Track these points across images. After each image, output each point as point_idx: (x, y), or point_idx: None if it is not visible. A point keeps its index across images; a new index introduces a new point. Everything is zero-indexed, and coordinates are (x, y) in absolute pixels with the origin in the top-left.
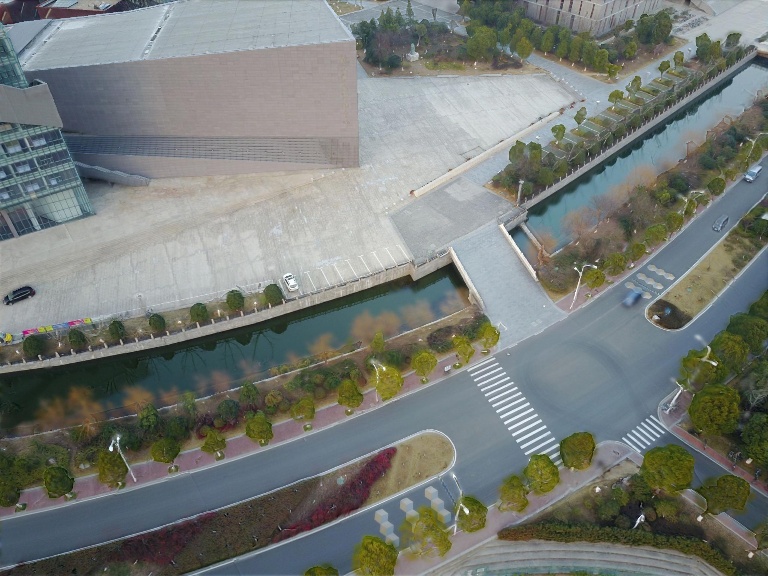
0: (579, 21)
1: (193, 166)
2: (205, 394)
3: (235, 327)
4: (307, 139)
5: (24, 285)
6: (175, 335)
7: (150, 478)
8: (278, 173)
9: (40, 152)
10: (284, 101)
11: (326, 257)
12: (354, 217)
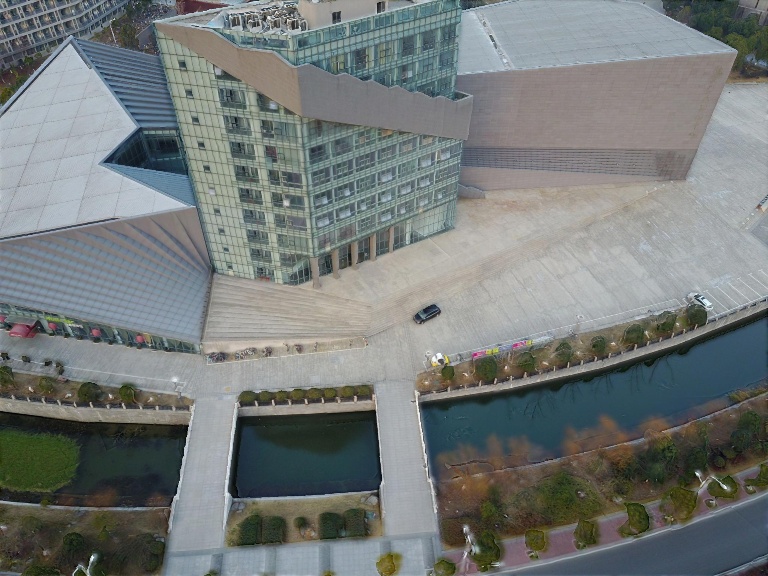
0: None
1: (528, 178)
2: (677, 421)
3: (660, 349)
4: (645, 151)
5: (424, 303)
6: (614, 357)
7: (693, 513)
8: (607, 185)
9: (441, 165)
10: (638, 112)
11: (715, 275)
12: (716, 233)
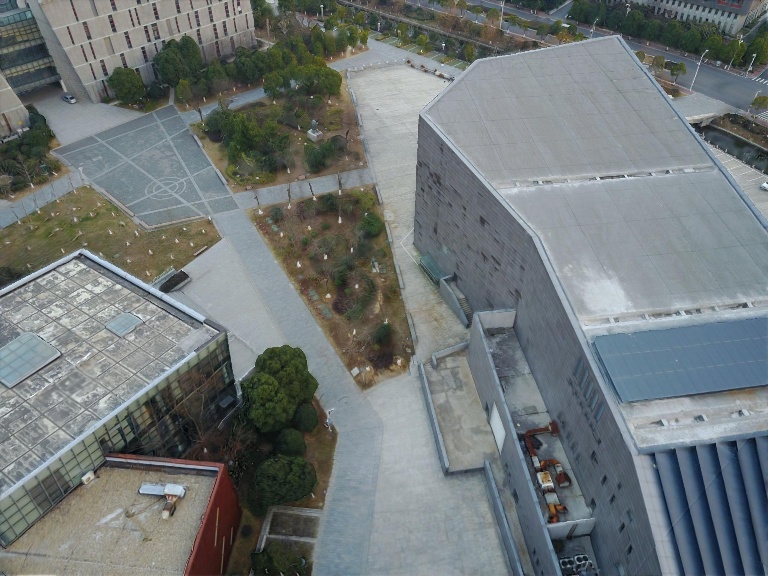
0: (240, 38)
1: None
2: None
3: None
4: None
5: None
6: None
7: None
8: None
9: None
10: None
11: None
12: None
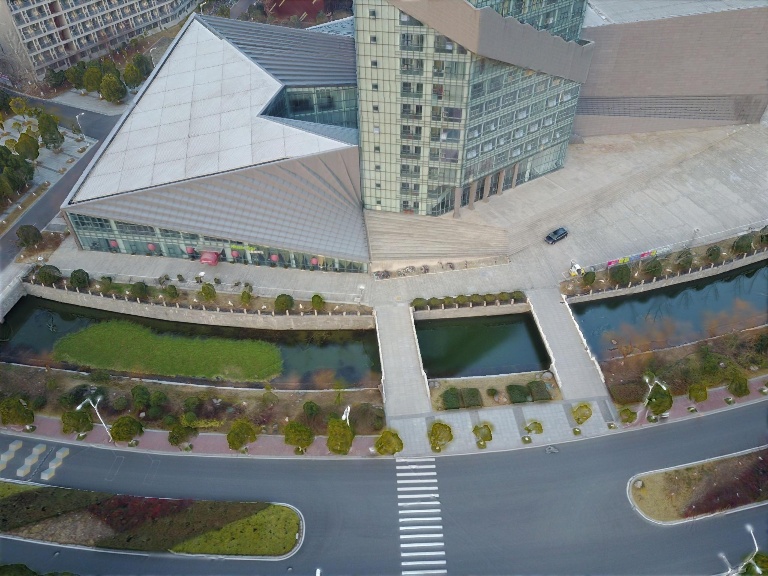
0: None
1: (621, 124)
2: None
3: (763, 259)
4: (725, 97)
5: (551, 228)
6: (727, 265)
7: None
8: (691, 130)
9: (562, 107)
10: (722, 60)
11: None
12: None
